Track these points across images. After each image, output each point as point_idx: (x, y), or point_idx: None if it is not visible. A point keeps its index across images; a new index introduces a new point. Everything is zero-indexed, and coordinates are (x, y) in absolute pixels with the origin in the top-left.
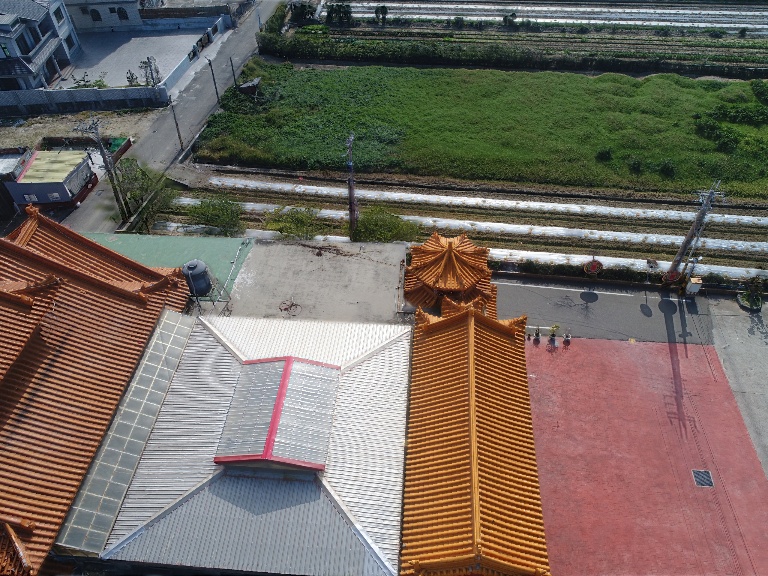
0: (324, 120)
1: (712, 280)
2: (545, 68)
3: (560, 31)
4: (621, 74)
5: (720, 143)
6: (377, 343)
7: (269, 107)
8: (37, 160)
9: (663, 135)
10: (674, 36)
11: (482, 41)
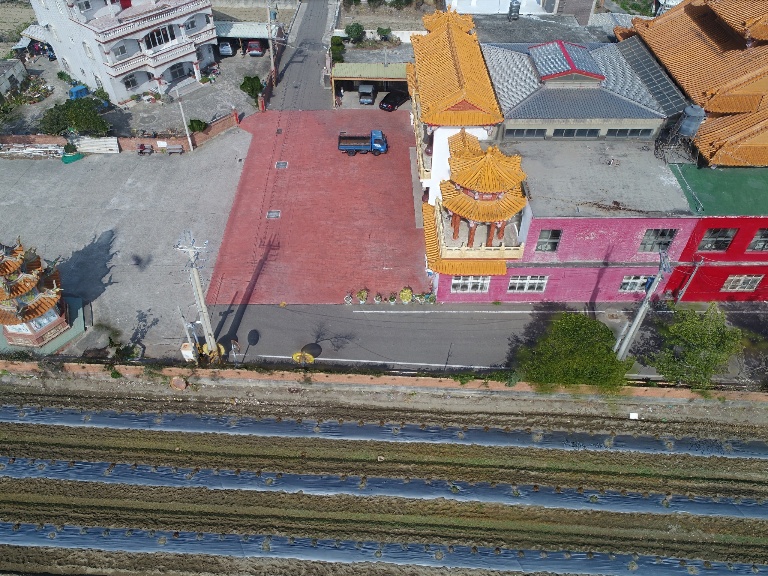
0: None
1: (162, 362)
2: None
3: None
4: None
5: None
6: (525, 105)
7: None
8: None
9: None
10: None
11: None
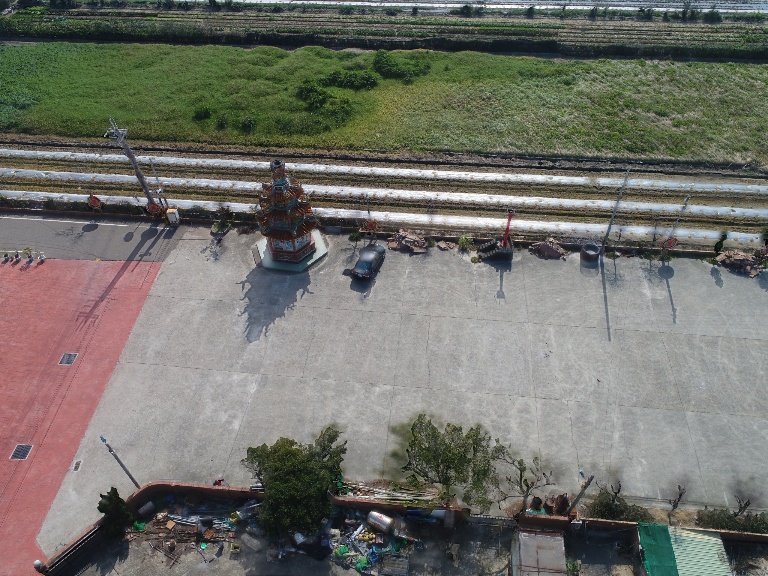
0: None
1: (193, 211)
2: (217, 43)
3: (257, 10)
4: (273, 47)
5: (309, 104)
6: None
7: None
8: None
9: (266, 98)
10: (356, 14)
11: (180, 20)
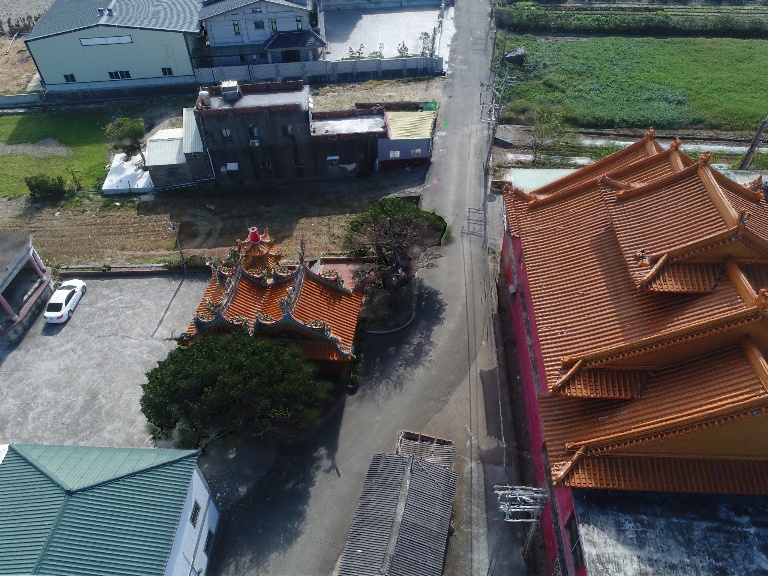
0: (602, 85)
1: None
2: None
3: (762, 4)
4: None
5: None
6: None
7: (540, 74)
8: (392, 120)
9: None
10: None
11: (695, 14)
